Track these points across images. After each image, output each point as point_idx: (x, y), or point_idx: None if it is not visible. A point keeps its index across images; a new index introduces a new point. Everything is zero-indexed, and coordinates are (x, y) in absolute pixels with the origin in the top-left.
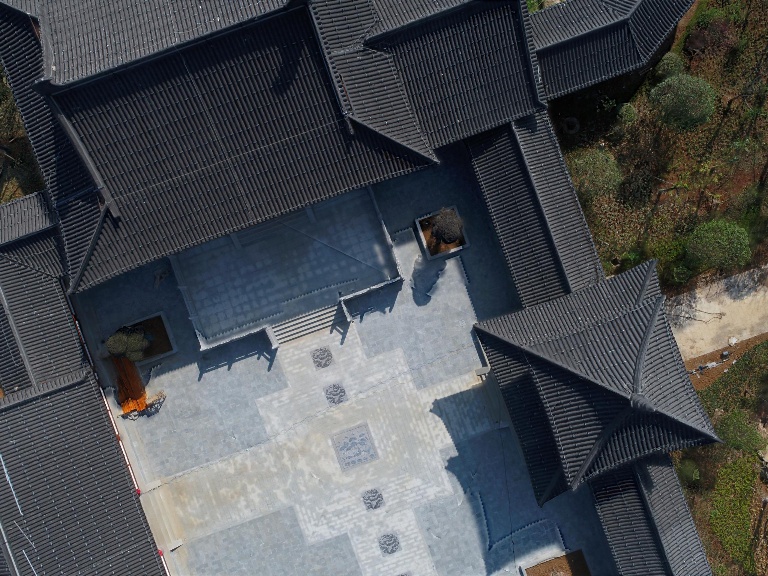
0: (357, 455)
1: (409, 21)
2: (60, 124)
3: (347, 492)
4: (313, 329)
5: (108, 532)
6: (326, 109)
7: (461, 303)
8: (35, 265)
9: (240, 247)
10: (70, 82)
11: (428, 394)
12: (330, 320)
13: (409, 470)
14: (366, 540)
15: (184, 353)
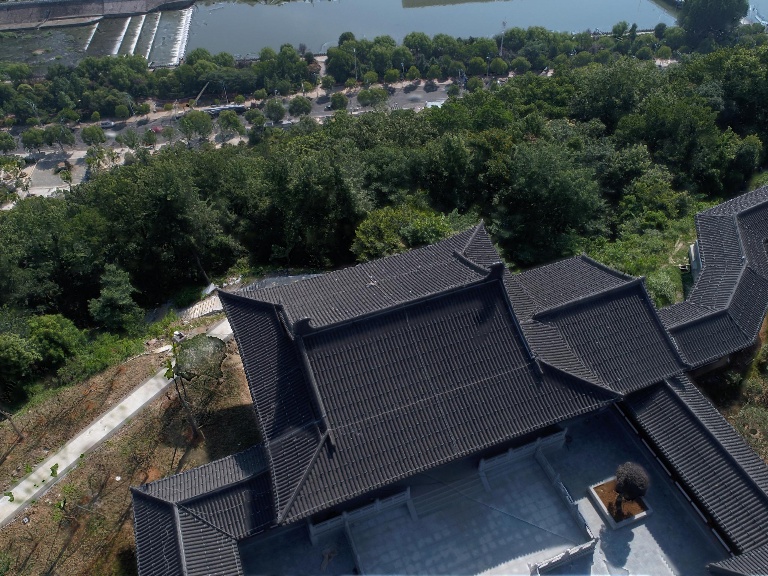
0: None
1: (567, 302)
2: (300, 362)
3: None
4: None
5: None
6: (517, 356)
7: None
8: (218, 524)
9: (416, 518)
10: (320, 326)
11: None
12: None
13: None
14: None
15: None
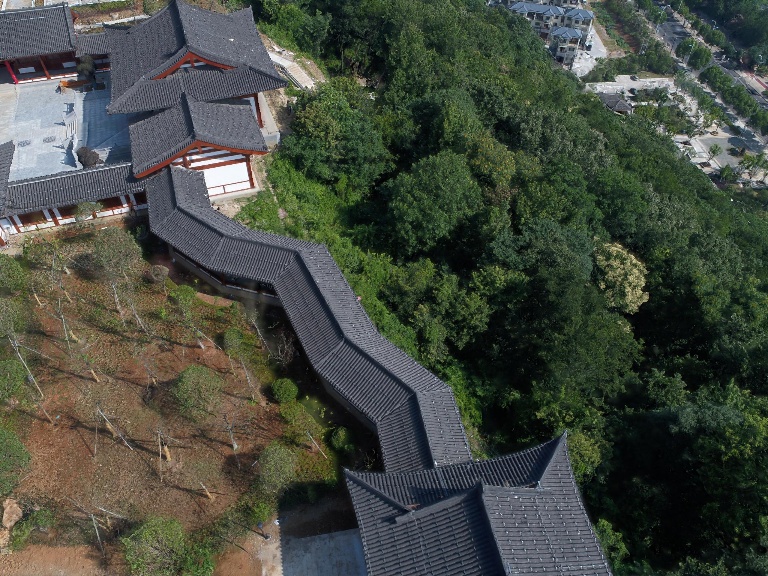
0: None
1: None
2: None
3: None
4: None
5: None
6: None
7: None
8: None
9: None
10: None
11: None
12: None
13: None
14: None
15: None
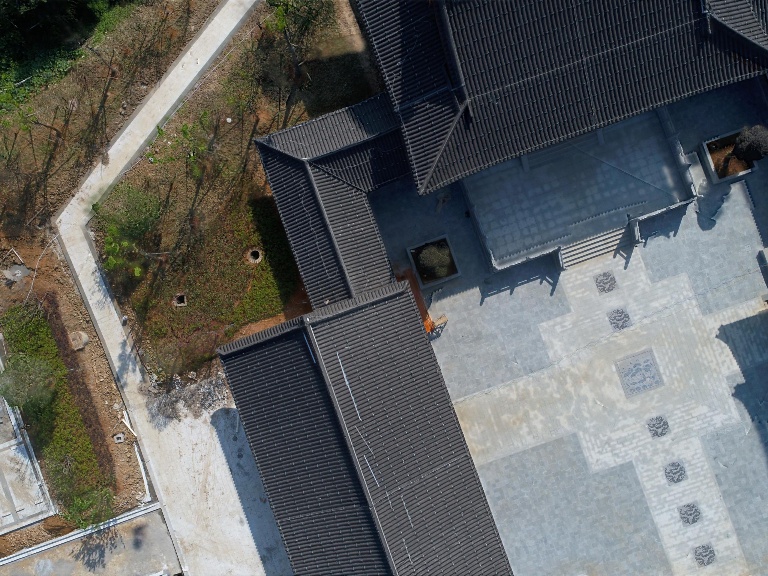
0: (642, 381)
1: None
2: (437, 18)
3: (632, 419)
4: (597, 253)
5: (431, 444)
6: (685, 8)
7: (747, 228)
8: (347, 179)
9: (528, 169)
10: None
11: (714, 320)
12: (615, 244)
13: (695, 397)
14: (651, 468)
15: (466, 277)
